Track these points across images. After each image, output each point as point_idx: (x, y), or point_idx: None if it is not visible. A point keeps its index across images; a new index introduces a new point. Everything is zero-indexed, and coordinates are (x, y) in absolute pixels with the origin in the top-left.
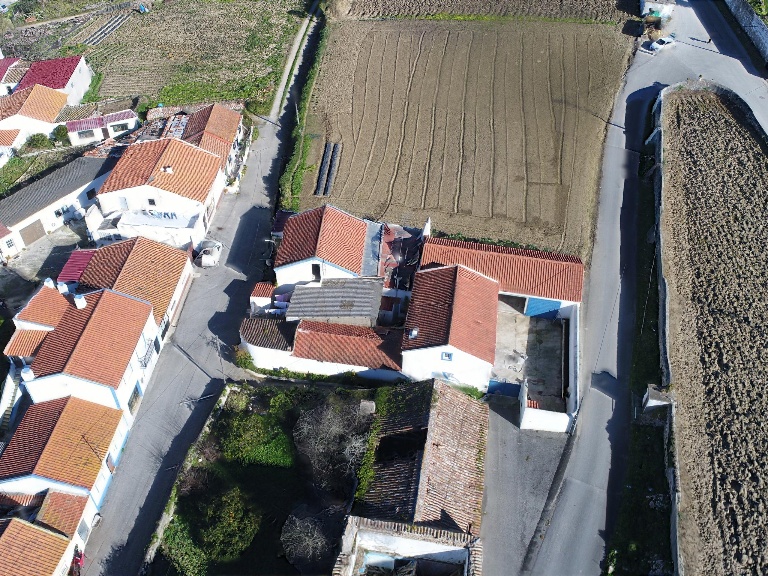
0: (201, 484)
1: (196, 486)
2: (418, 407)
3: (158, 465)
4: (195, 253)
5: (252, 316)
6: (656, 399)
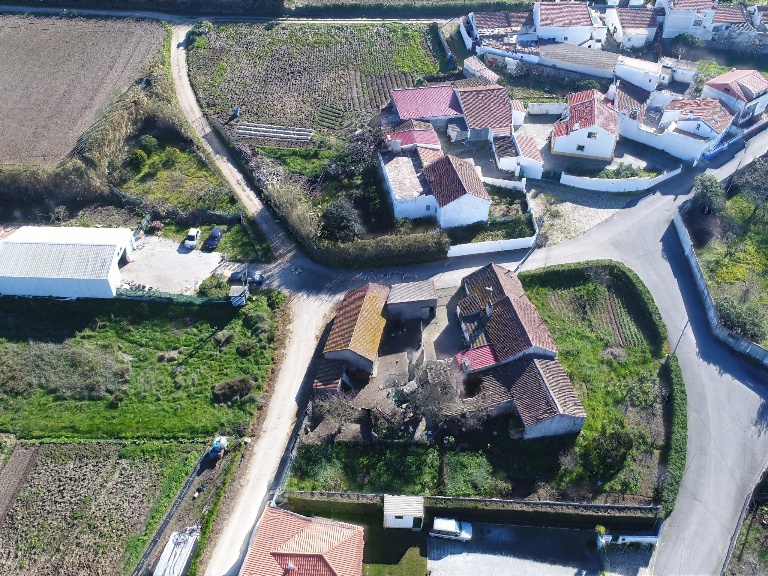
0: None
1: None
2: None
3: None
4: None
5: None
6: None
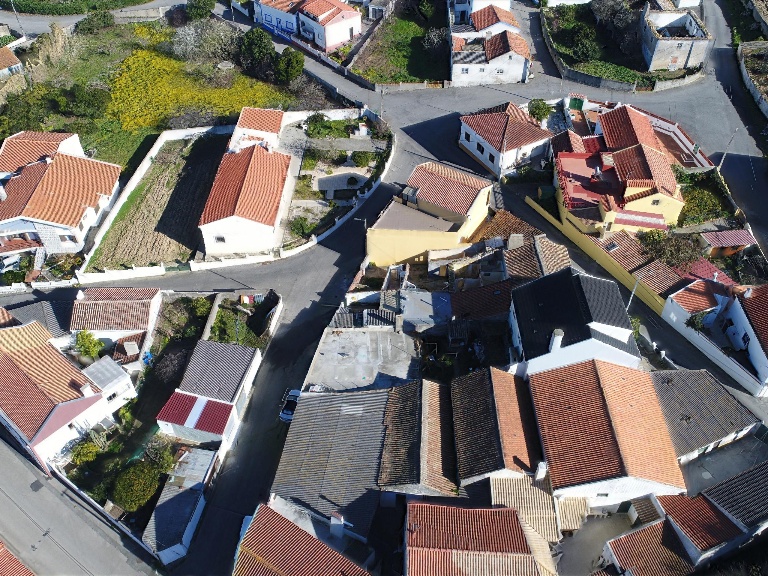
0: None
1: (559, 29)
2: None
3: (530, 35)
4: None
5: None
6: None
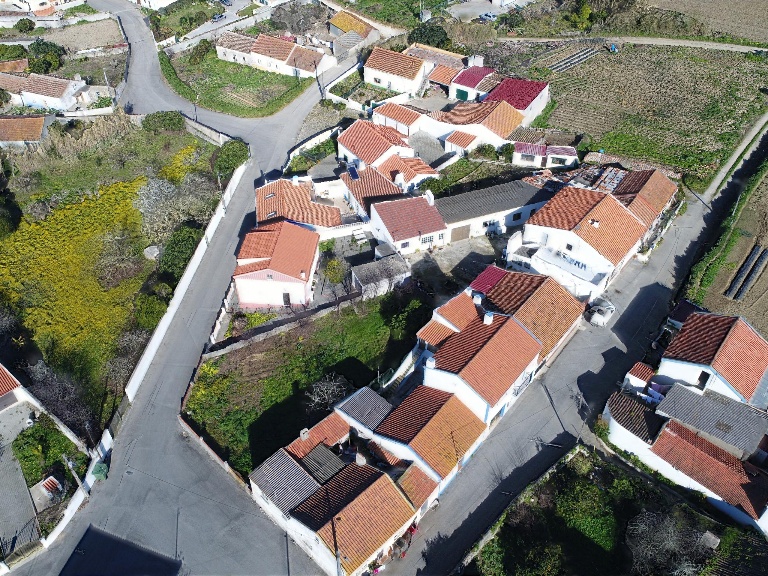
0: (529, 524)
1: (524, 523)
2: (767, 570)
3: (496, 484)
4: (588, 306)
5: (623, 392)
6: None
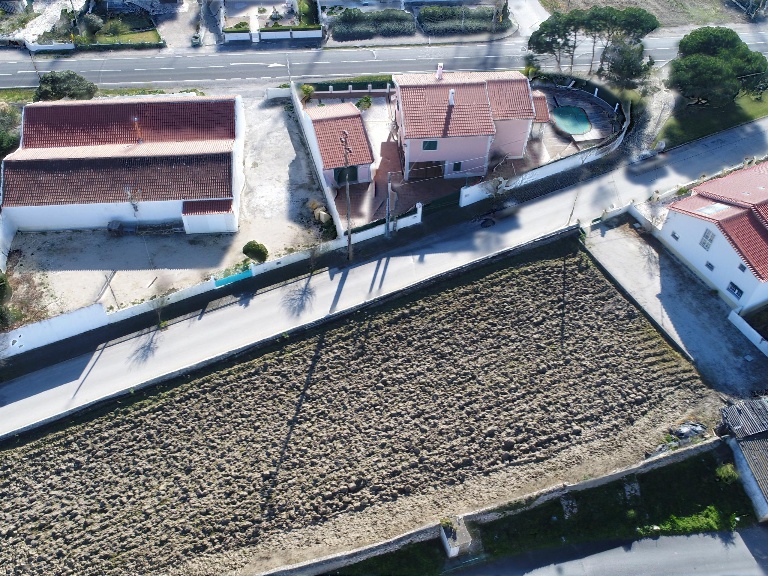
0: None
1: None
2: None
3: None
4: None
5: None
6: (469, 534)
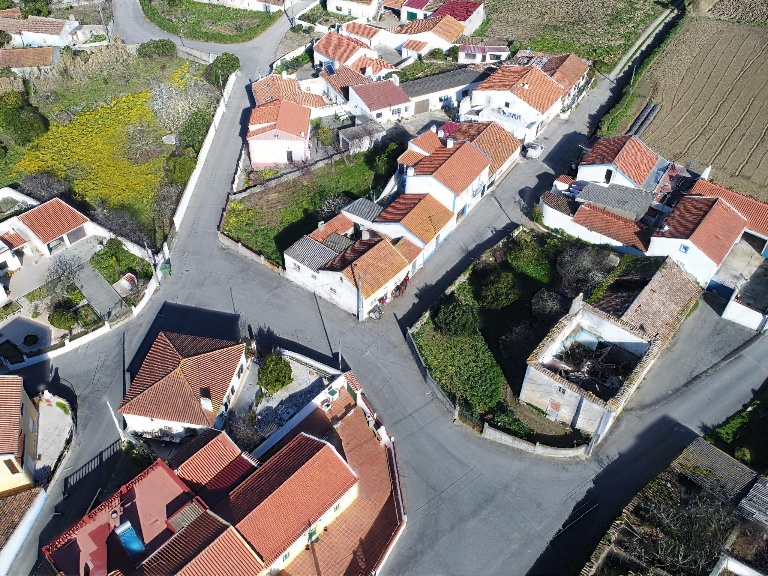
0: None
1: (486, 267)
2: (650, 268)
3: (464, 254)
4: (524, 148)
5: (552, 192)
6: None
